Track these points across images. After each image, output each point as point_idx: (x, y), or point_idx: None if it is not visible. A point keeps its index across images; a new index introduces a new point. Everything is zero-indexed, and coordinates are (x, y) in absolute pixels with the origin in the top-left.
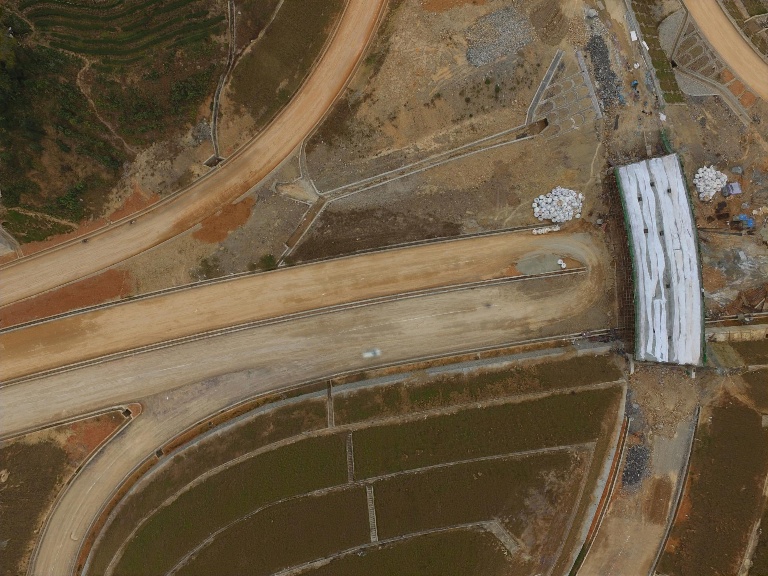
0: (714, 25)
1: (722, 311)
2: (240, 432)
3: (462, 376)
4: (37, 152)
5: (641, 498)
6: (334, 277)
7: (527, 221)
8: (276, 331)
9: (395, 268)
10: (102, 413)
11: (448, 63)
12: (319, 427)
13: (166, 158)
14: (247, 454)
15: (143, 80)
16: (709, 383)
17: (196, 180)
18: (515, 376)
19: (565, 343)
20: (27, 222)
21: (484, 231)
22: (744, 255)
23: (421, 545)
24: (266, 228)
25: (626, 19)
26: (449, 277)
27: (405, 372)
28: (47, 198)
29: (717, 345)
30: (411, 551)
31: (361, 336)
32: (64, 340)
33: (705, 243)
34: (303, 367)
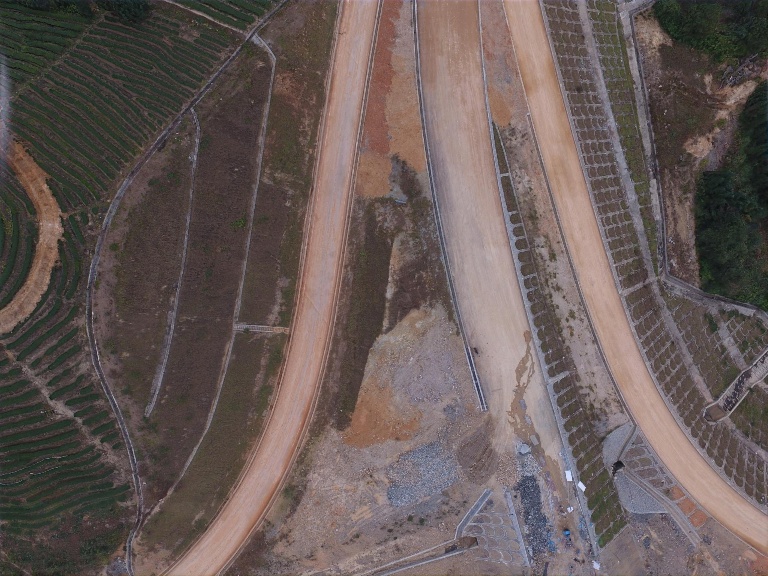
0: (665, 437)
1: None
2: None
3: None
4: None
5: None
6: None
7: None
8: None
9: None
10: None
11: (368, 502)
12: None
13: None
14: None
15: None
16: None
17: None
18: None
19: None
20: None
21: None
22: None
23: None
24: None
25: (561, 457)
26: None
27: None
28: None
29: None
30: None
31: None
32: None
33: None
34: None
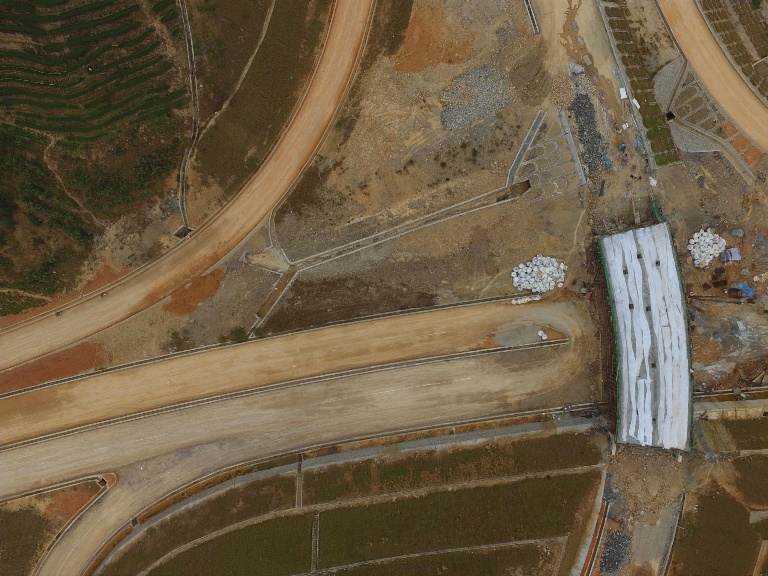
0: (716, 74)
1: (716, 385)
2: (210, 507)
3: (435, 453)
4: (9, 227)
5: None
6: (305, 349)
7: (506, 291)
8: (247, 403)
9: (367, 339)
10: (79, 482)
11: (422, 127)
12: (286, 507)
13: (135, 231)
14: (215, 532)
15: (108, 156)
16: (696, 468)
17: (166, 252)
18: (490, 454)
19: (545, 418)
20: (1, 298)
21: (460, 301)
22: (743, 325)
23: None
24: (236, 300)
25: (615, 75)
26: (423, 349)
27: (377, 446)
28: (20, 273)
29: (708, 424)
30: None
31: (333, 409)
32: (41, 410)
33: (700, 312)
34: (274, 439)
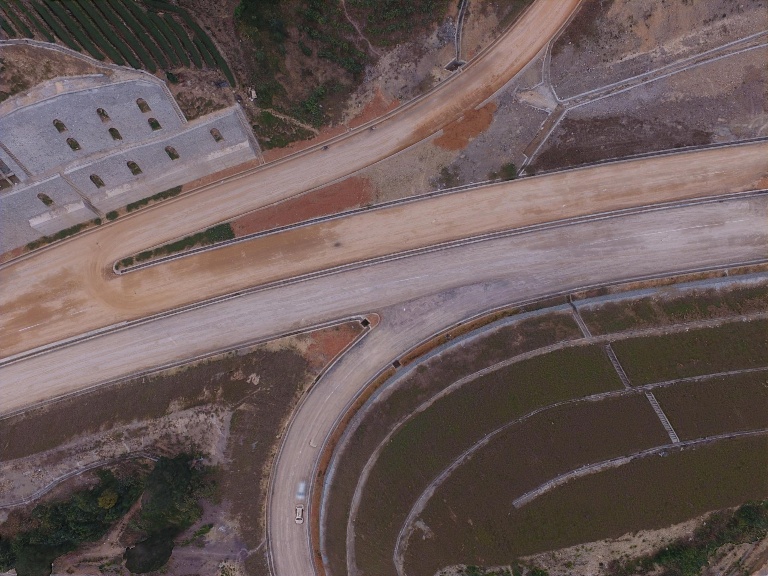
0: None
1: None
2: (486, 343)
3: (714, 291)
4: (282, 55)
5: None
6: (575, 188)
7: None
8: (514, 243)
9: (639, 179)
10: (341, 322)
11: None
12: (575, 337)
13: (410, 60)
14: (502, 362)
15: None
16: None
17: (437, 85)
18: None
19: None
20: (275, 126)
21: (737, 140)
22: None
23: (727, 447)
24: (508, 135)
25: None
26: (696, 189)
27: (648, 288)
28: (293, 102)
29: None
30: (717, 453)
31: (602, 250)
32: (303, 249)
33: None
34: (541, 281)
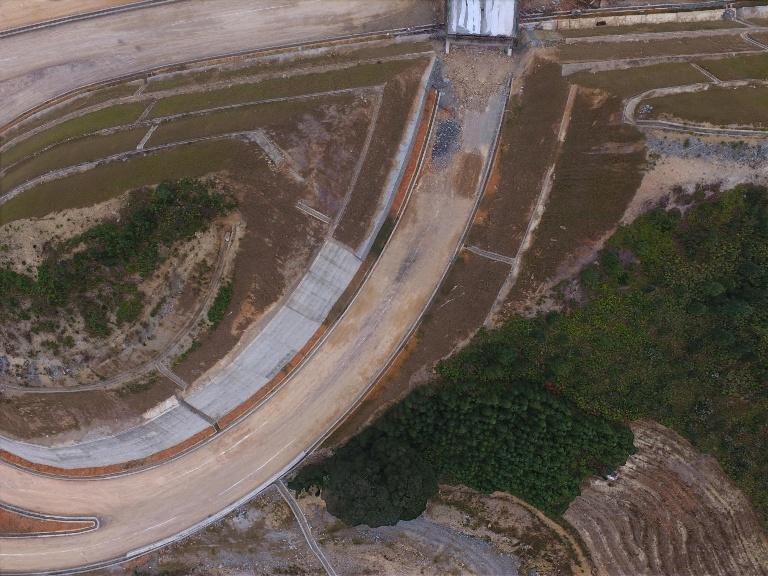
0: None
1: (555, 7)
2: (56, 111)
3: (277, 62)
4: None
5: (450, 172)
6: None
7: None
8: (99, 25)
9: None
10: None
11: None
12: (125, 96)
13: None
14: (55, 120)
15: None
16: (524, 57)
17: None
18: (329, 59)
19: (388, 38)
20: None
21: None
22: None
23: (184, 151)
24: None
25: None
26: None
27: None
28: None
29: (542, 31)
30: (172, 155)
31: (183, 31)
32: None
33: None
34: (126, 61)
